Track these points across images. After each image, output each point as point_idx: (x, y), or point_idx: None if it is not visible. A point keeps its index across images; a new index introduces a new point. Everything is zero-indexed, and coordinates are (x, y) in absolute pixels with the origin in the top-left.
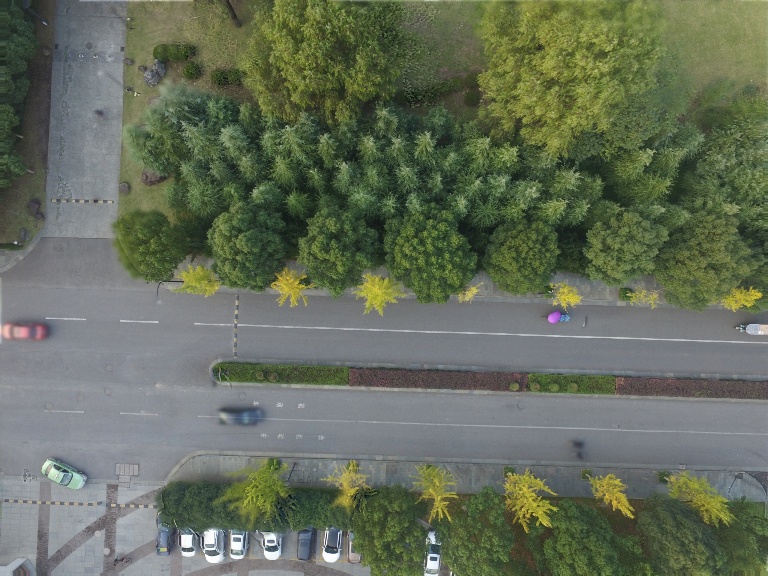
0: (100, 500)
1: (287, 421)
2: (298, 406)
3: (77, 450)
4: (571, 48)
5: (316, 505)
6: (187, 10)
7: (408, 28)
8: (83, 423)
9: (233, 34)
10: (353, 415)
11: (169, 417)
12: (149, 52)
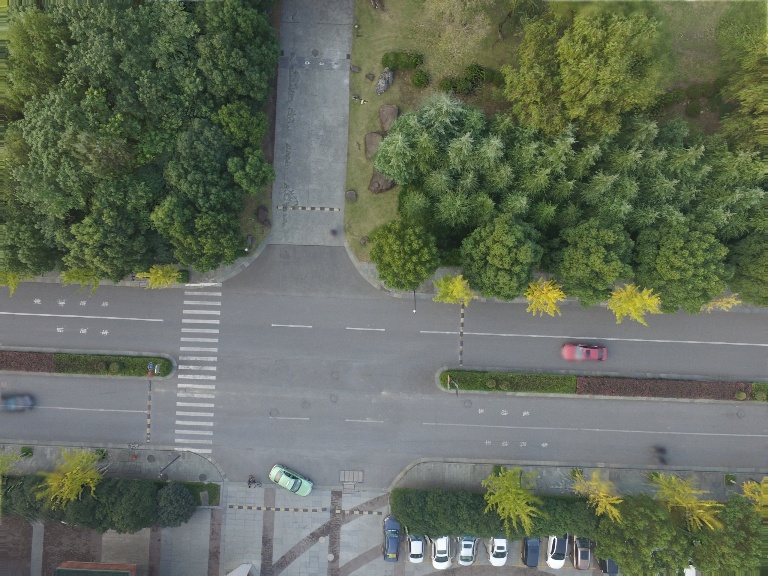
0: (324, 506)
1: (511, 429)
2: (523, 414)
3: (302, 457)
4: None
5: (553, 512)
6: (413, 18)
7: (630, 39)
8: (308, 430)
9: (459, 43)
10: (576, 423)
11: (394, 424)
12: (376, 60)
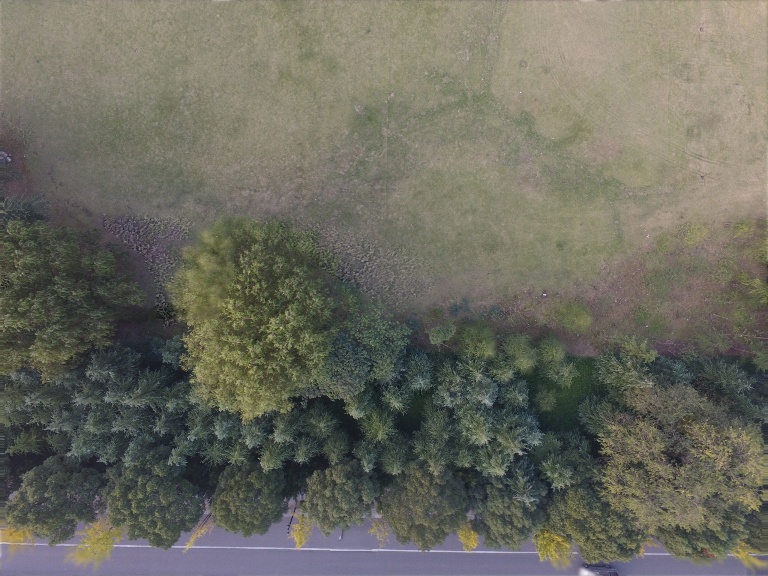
0: None
1: None
2: None
3: None
4: (327, 259)
5: None
6: None
7: (162, 241)
8: None
9: None
10: None
11: None
12: None
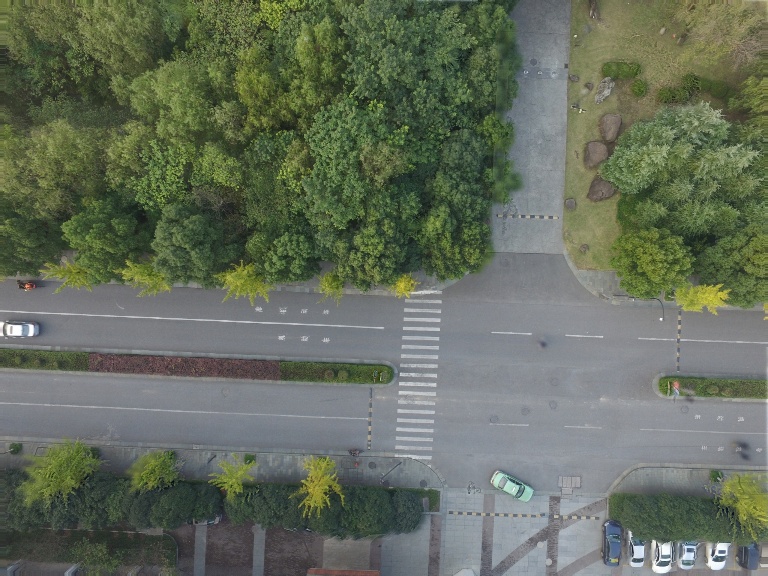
0: (543, 512)
1: (727, 434)
2: (738, 419)
3: (521, 463)
4: None
5: None
6: (629, 28)
7: None
8: (528, 436)
9: (675, 52)
10: None
11: (612, 430)
12: (594, 69)
